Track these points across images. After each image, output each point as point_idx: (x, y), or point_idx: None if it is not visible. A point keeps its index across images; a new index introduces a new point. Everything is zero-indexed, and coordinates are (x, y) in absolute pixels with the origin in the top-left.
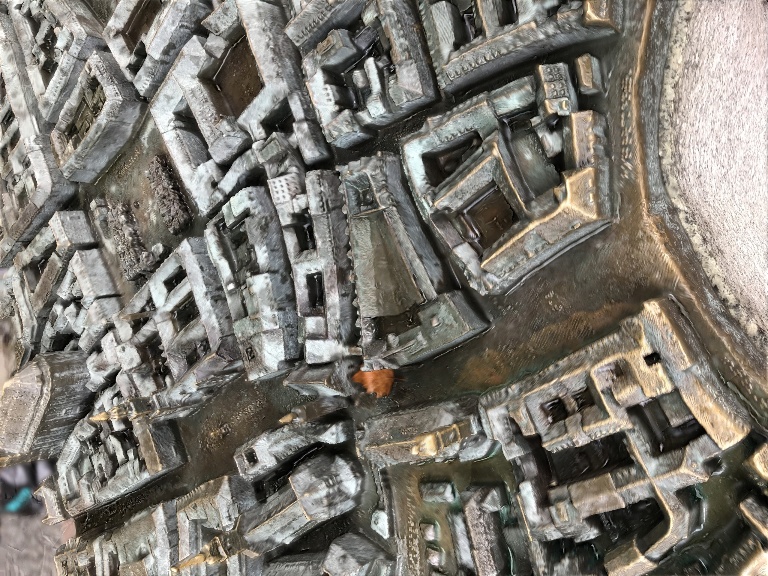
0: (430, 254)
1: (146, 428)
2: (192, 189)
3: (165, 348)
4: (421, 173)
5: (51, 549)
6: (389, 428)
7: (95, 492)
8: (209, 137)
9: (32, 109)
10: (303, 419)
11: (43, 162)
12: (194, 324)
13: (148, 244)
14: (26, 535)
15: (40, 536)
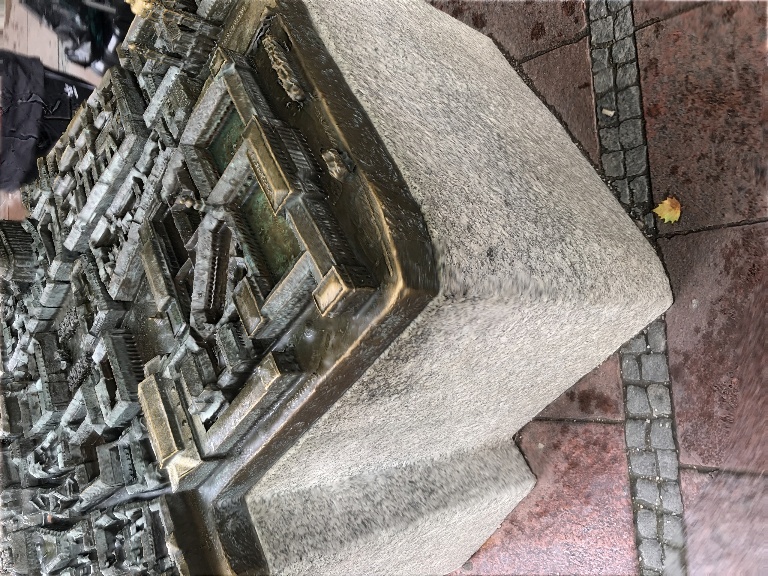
0: (64, 564)
1: (17, 361)
2: (62, 422)
3: (27, 392)
4: (68, 575)
5: (6, 206)
6: (20, 545)
7: (0, 308)
8: (73, 441)
9: (99, 209)
10: (10, 507)
11: (76, 239)
12: (32, 421)
13: (75, 338)
14: (0, 187)
15: (7, 193)
